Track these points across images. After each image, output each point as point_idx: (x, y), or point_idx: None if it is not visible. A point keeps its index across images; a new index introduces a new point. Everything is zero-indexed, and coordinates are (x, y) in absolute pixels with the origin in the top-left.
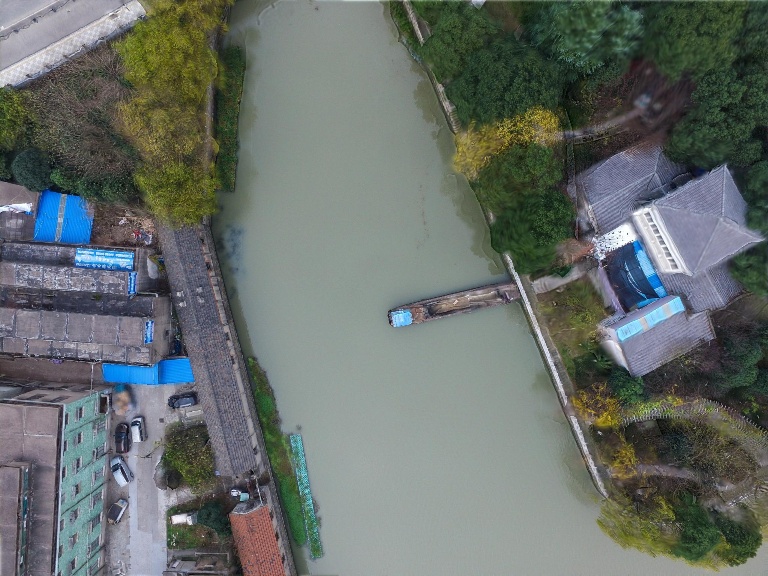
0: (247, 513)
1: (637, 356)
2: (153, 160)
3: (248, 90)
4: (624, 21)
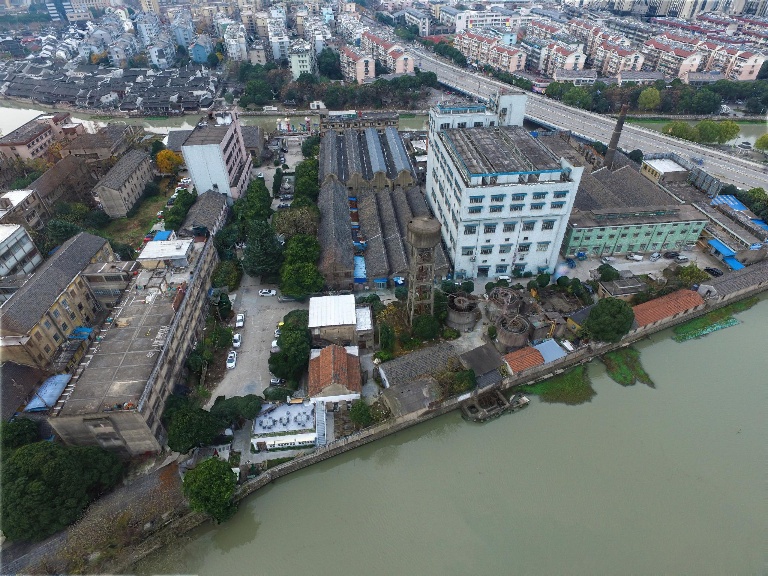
0: None
1: None
2: None
3: None
4: None
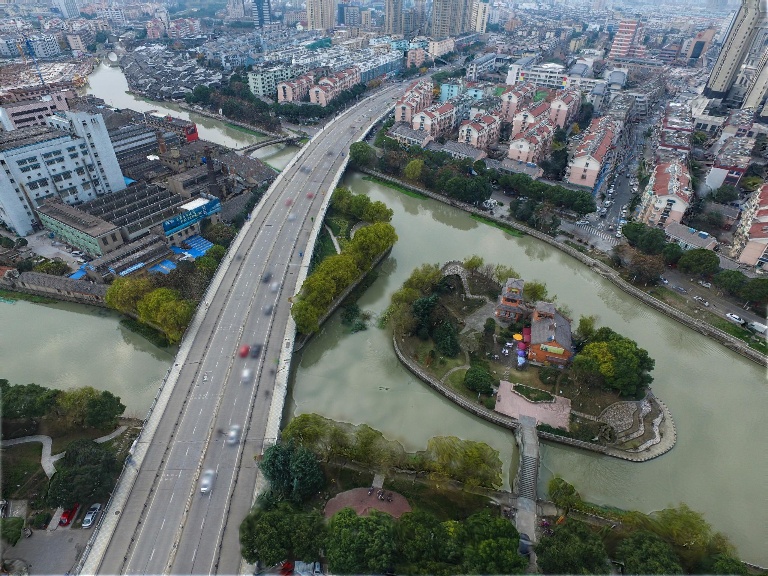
0: (7, 271)
1: None
2: None
3: (168, 360)
4: None
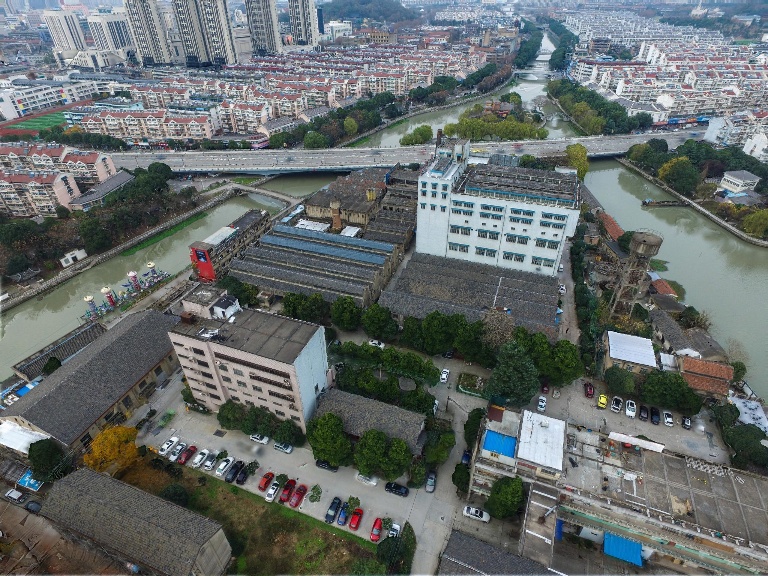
0: None
1: (737, 202)
2: (577, 158)
3: None
4: (700, 151)
